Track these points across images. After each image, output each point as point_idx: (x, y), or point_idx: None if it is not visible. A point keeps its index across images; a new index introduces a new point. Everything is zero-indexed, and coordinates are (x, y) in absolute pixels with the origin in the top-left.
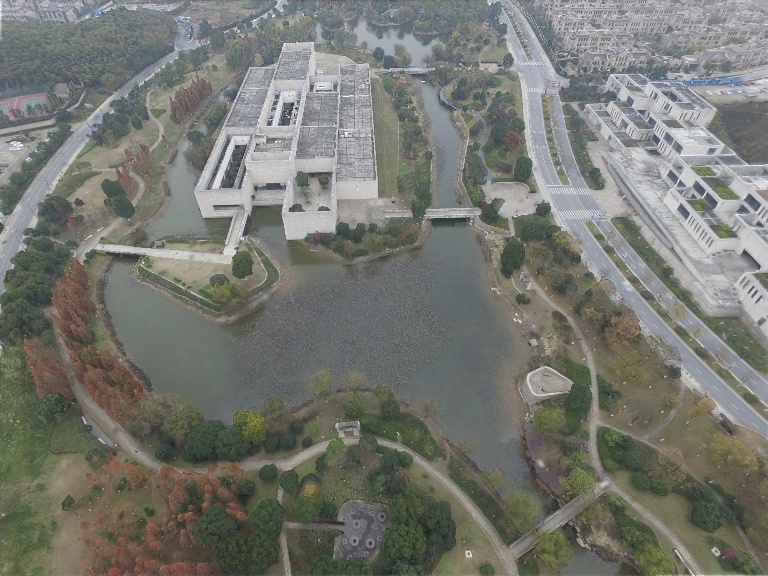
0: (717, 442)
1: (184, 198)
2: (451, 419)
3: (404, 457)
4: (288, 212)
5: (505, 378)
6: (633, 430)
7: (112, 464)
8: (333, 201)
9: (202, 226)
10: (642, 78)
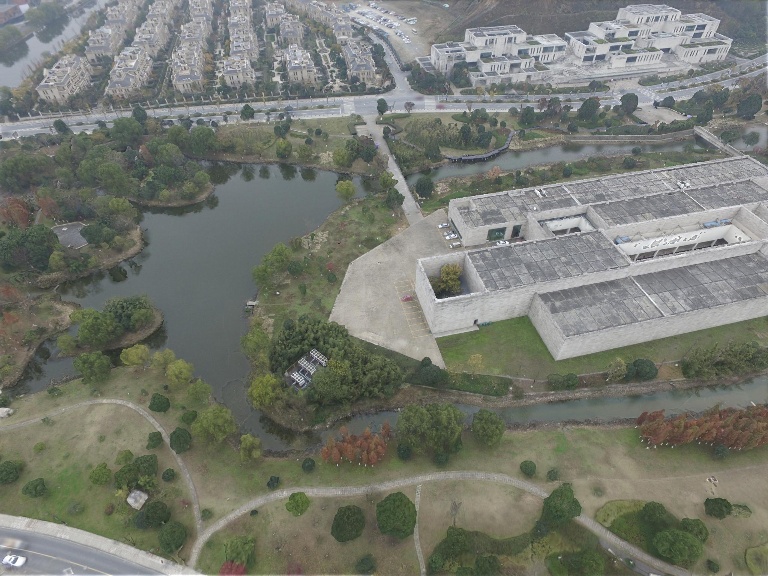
0: None
1: None
2: None
3: None
4: None
5: None
6: None
7: None
8: None
9: None
10: (441, 45)
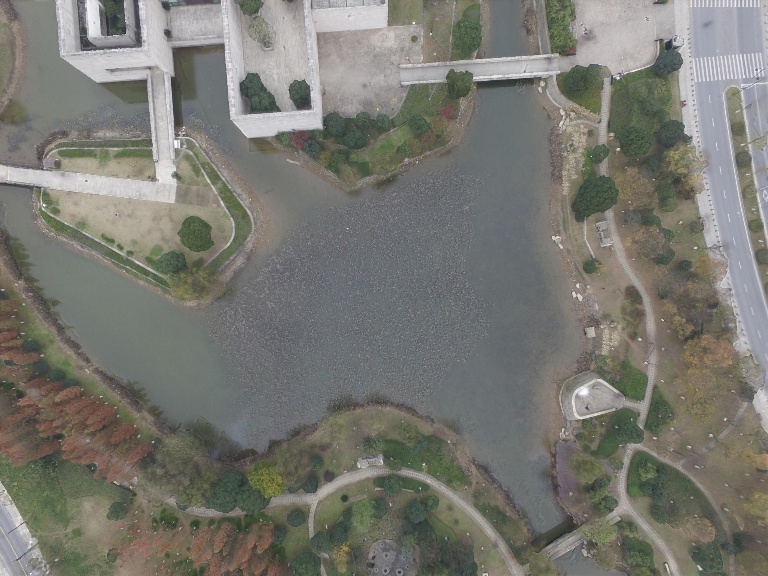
0: (755, 505)
1: (45, 22)
2: (480, 435)
3: (431, 507)
4: (241, 115)
5: (546, 382)
6: (671, 455)
7: (140, 549)
8: (313, 81)
9: (102, 104)
10: None
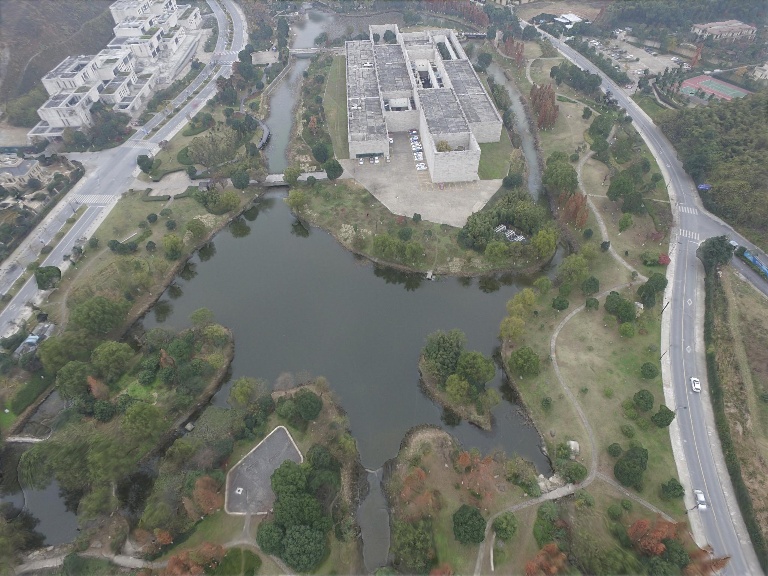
0: None
1: None
2: (326, 15)
3: None
4: (393, 24)
5: (304, 20)
6: None
7: None
8: (370, 28)
9: None
10: (48, 104)
